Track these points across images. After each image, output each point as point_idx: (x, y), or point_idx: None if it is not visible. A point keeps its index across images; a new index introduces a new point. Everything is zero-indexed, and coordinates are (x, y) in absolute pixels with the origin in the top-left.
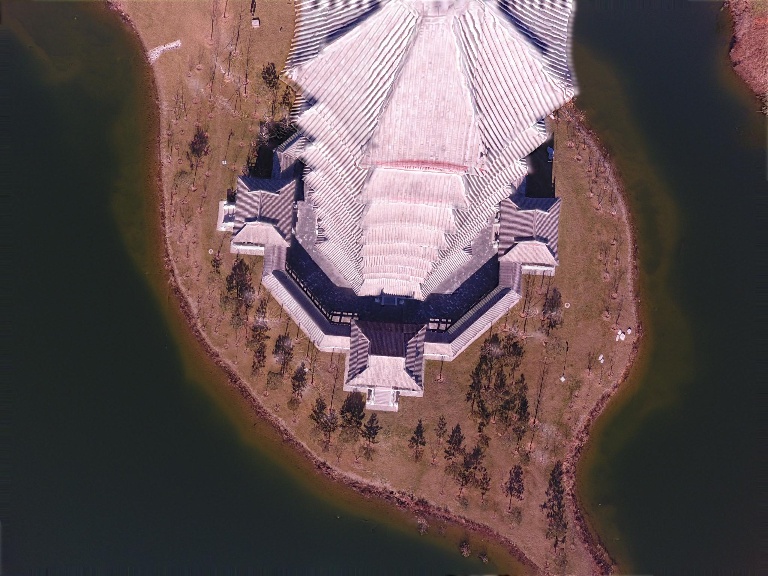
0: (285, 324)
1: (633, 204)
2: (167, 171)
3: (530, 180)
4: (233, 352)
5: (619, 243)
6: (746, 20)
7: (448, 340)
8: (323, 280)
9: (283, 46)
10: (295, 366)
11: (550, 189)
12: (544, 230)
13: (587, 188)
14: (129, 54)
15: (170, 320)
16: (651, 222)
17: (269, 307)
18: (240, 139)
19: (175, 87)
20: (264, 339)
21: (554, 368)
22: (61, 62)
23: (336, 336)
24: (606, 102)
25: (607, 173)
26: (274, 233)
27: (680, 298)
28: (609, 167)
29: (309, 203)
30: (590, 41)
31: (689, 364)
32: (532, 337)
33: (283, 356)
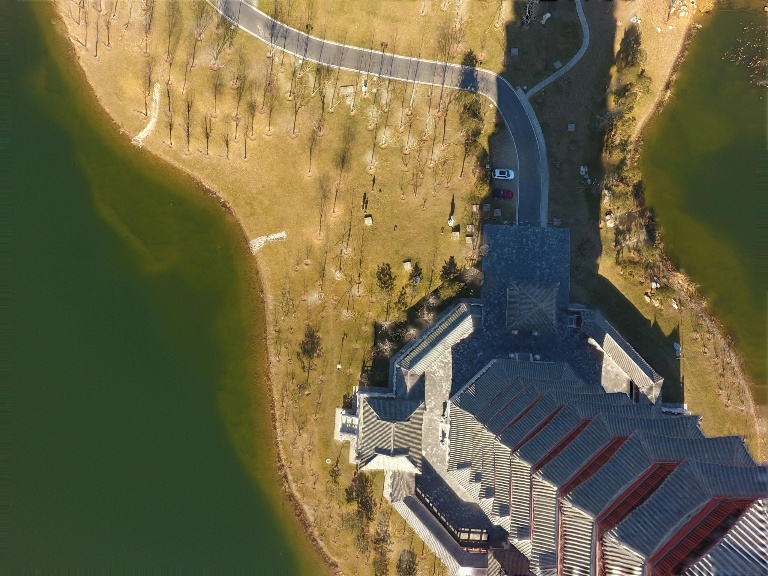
0: (409, 539)
1: (760, 394)
2: (276, 370)
3: None
4: (353, 563)
5: (749, 440)
6: None
7: None
8: (449, 495)
9: (398, 245)
10: None
11: (679, 389)
12: None
13: (715, 384)
14: (229, 242)
15: (284, 527)
16: None
17: (392, 521)
18: (354, 340)
19: (281, 281)
20: (387, 552)
21: None
22: (159, 252)
23: (473, 568)
24: (727, 284)
25: (733, 363)
26: (405, 461)
27: None
28: (734, 356)
29: (431, 412)
30: (708, 218)
31: None
32: None
33: (408, 571)
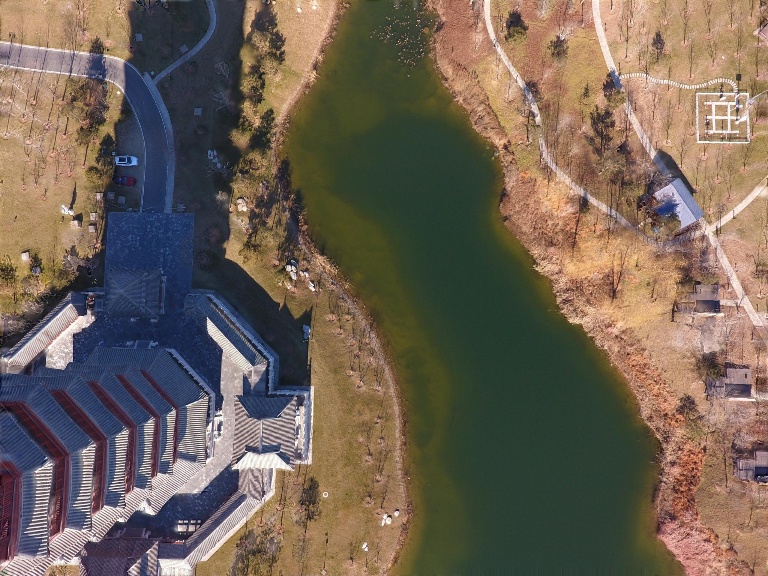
0: None
1: (403, 374)
2: None
3: (285, 363)
4: None
5: (385, 420)
6: (514, 172)
7: (184, 554)
8: None
9: (18, 236)
10: (47, 573)
11: (305, 371)
12: (275, 437)
13: (347, 365)
14: None
15: None
16: (423, 391)
17: None
18: None
19: None
20: None
21: (314, 562)
22: None
23: None
24: (374, 264)
25: (373, 344)
26: None
27: (454, 470)
28: (376, 337)
29: None
30: (357, 199)
31: (463, 542)
32: (289, 531)
33: None
